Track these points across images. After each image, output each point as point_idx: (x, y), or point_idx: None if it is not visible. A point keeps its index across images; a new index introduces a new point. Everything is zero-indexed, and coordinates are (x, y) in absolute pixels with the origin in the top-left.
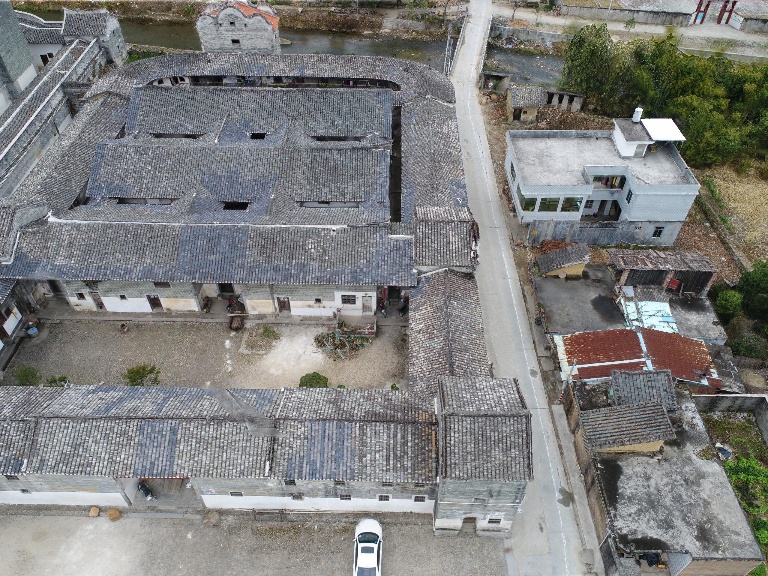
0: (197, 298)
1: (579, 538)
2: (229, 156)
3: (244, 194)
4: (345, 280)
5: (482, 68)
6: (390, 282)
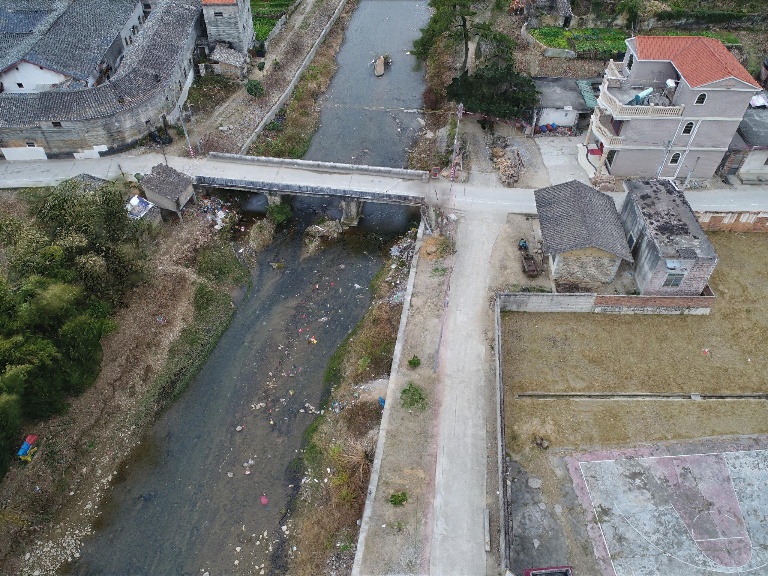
0: None
1: None
2: None
3: None
4: None
5: (225, 184)
6: None
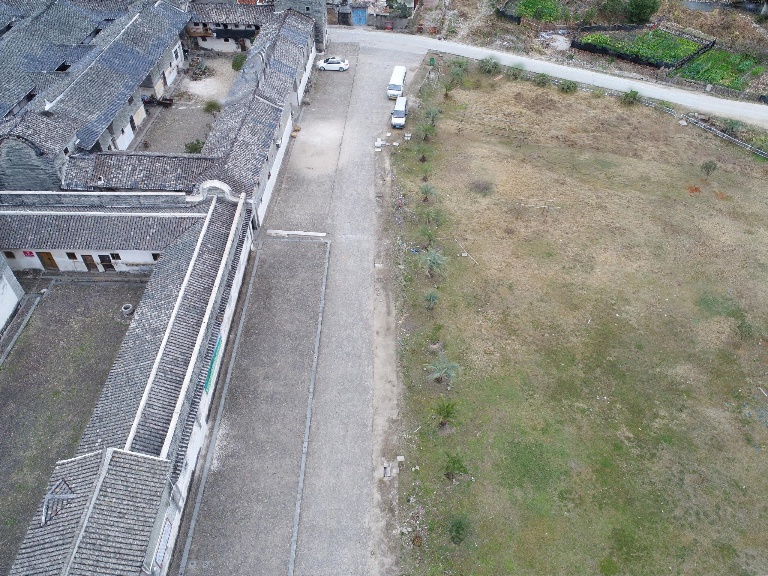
0: (142, 103)
1: (334, 28)
2: (8, 51)
3: (55, 60)
4: (177, 31)
5: None
6: (186, 20)
